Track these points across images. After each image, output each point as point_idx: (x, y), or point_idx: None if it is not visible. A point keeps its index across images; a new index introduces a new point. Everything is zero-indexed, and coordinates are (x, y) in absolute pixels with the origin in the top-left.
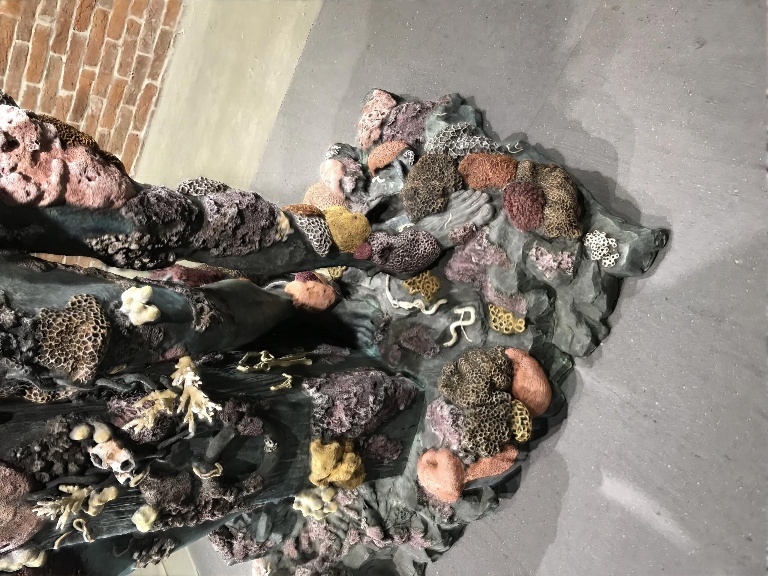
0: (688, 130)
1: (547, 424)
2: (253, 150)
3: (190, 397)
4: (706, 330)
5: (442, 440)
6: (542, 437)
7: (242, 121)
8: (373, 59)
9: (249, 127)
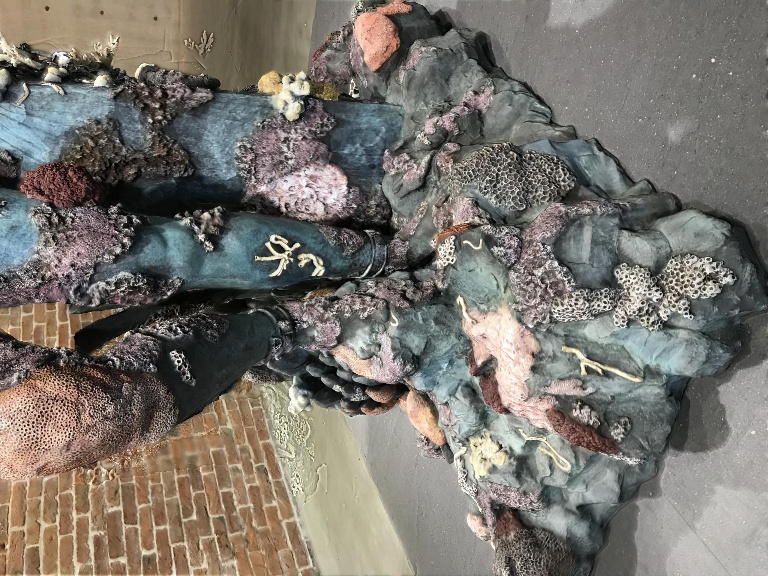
0: (350, 2)
1: (445, 25)
2: None
3: None
4: None
5: (358, 47)
6: (452, 25)
7: (376, 528)
8: None
9: (379, 516)
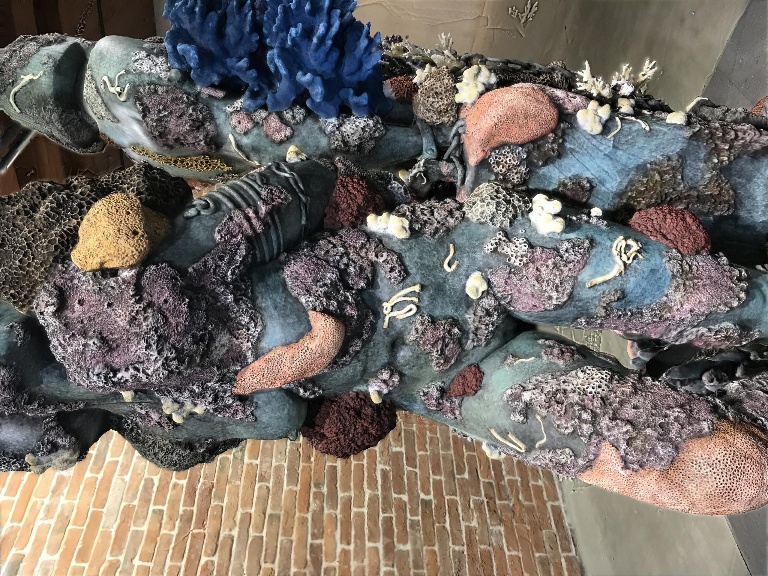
0: None
1: None
2: (712, 546)
3: (637, 82)
4: None
5: None
6: None
7: (685, 548)
8: None
9: (692, 538)
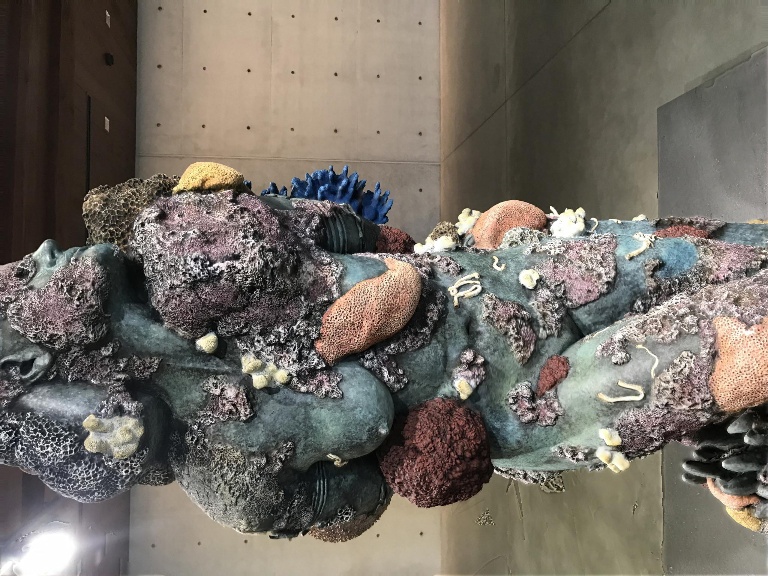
0: None
1: None
2: None
3: None
4: (766, 176)
5: None
6: None
7: None
8: (759, 534)
9: None
